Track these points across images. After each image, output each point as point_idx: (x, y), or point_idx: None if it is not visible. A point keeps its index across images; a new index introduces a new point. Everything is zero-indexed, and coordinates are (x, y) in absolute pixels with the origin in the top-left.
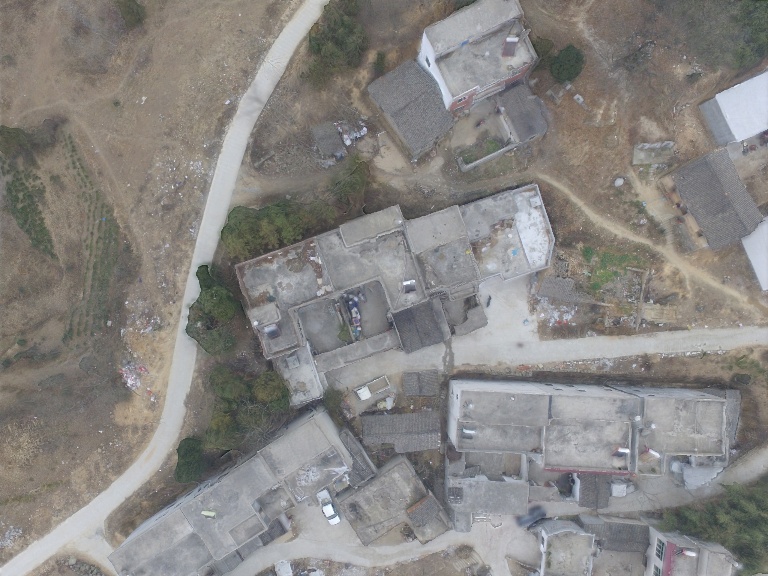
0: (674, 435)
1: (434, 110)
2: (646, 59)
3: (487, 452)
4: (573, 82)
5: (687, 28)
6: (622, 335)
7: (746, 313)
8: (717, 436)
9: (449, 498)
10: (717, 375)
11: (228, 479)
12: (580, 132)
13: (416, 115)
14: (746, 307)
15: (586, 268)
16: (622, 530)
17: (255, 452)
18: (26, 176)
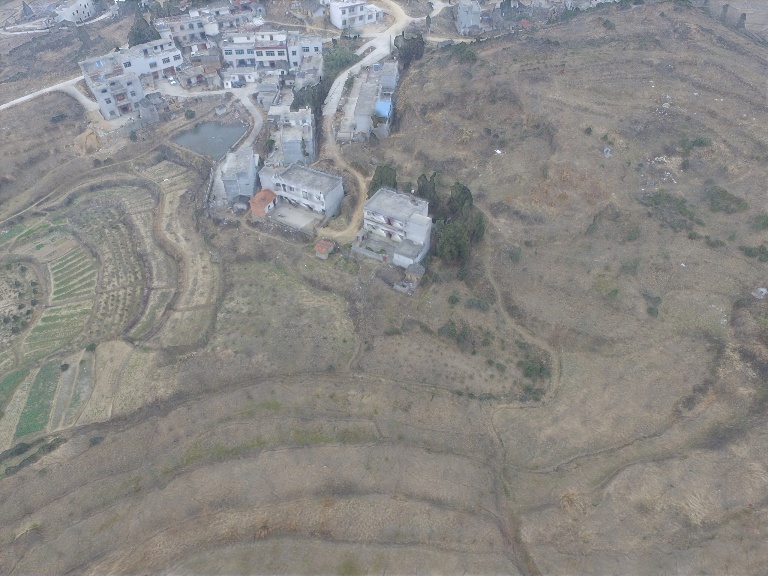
0: None
1: (227, 4)
2: None
3: (232, 46)
4: None
5: None
6: None
7: None
8: None
9: (221, 70)
10: None
11: (132, 48)
12: None
13: (221, 4)
14: None
15: None
16: None
17: (145, 43)
18: (84, 52)
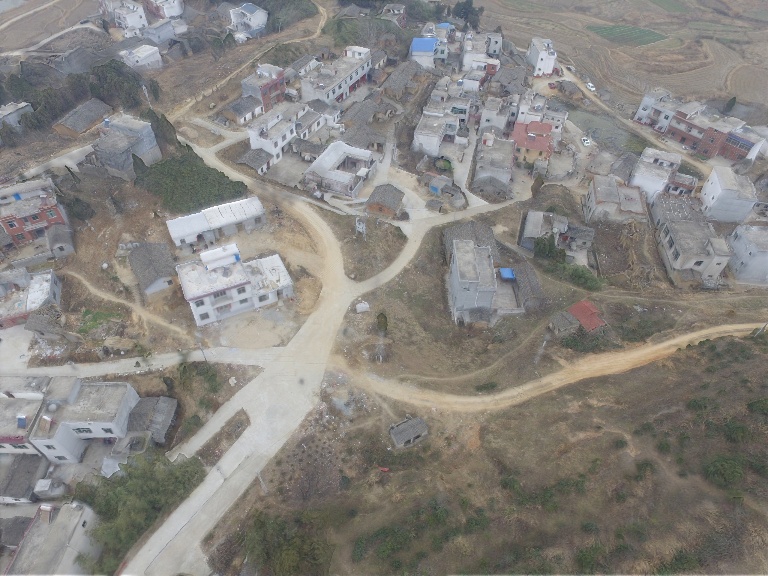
0: (80, 412)
1: None
2: (131, 209)
3: None
4: (89, 221)
5: (161, 199)
6: (93, 362)
7: (184, 341)
8: (116, 412)
9: None
10: (160, 388)
11: None
12: (92, 245)
13: None
14: (184, 337)
15: (81, 321)
16: (27, 521)
17: None
18: None
